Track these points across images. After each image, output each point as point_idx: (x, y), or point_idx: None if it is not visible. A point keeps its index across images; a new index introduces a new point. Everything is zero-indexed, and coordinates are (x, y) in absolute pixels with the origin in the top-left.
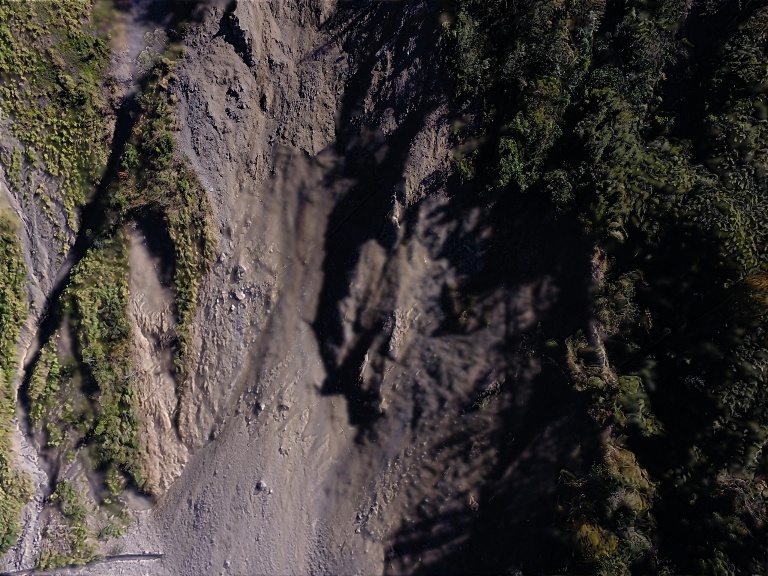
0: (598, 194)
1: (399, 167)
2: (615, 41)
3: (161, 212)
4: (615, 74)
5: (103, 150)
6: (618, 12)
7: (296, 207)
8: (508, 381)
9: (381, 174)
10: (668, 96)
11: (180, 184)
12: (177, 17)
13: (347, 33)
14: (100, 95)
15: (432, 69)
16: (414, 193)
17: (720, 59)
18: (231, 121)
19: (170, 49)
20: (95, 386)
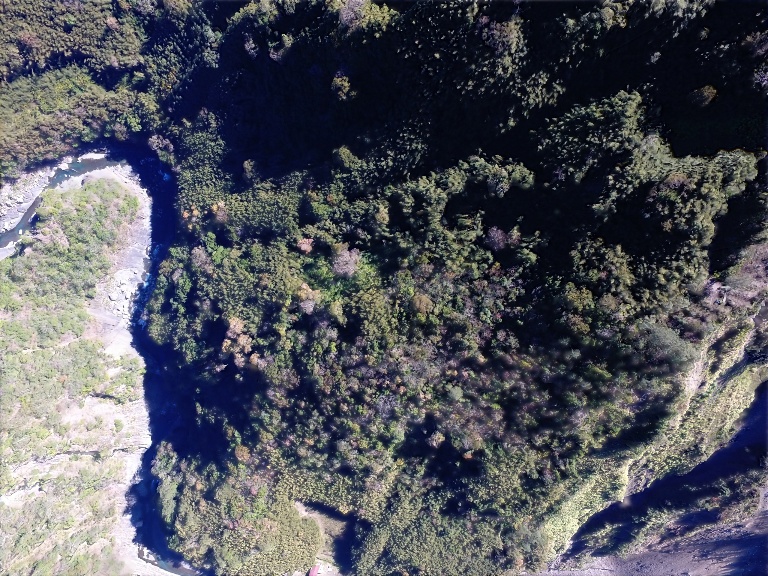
0: None
1: None
2: None
3: None
4: None
5: None
6: None
7: None
8: None
9: None
10: None
11: None
12: None
13: None
14: None
15: None
16: None
17: None
18: None
19: None
20: (627, 539)
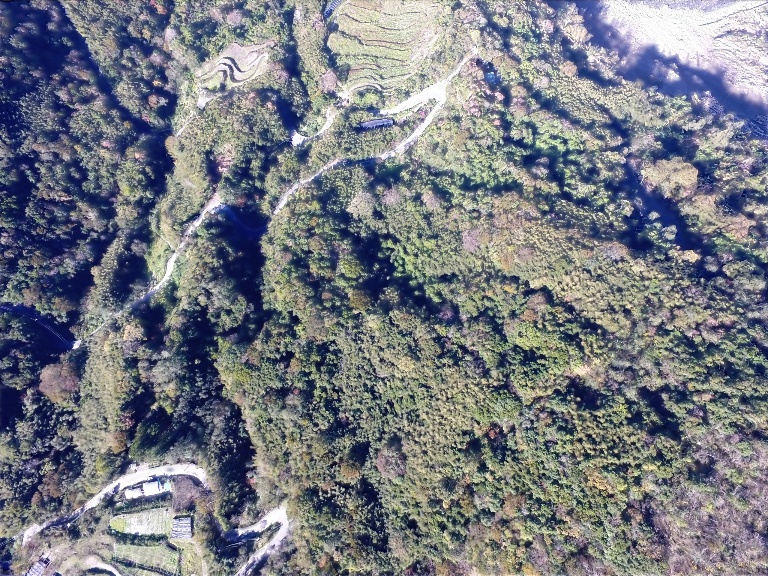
0: None
1: None
2: None
3: None
4: None
5: None
6: None
7: None
8: (620, 64)
9: None
10: None
11: None
12: None
13: None
14: None
15: None
16: None
17: None
18: None
19: None
20: None
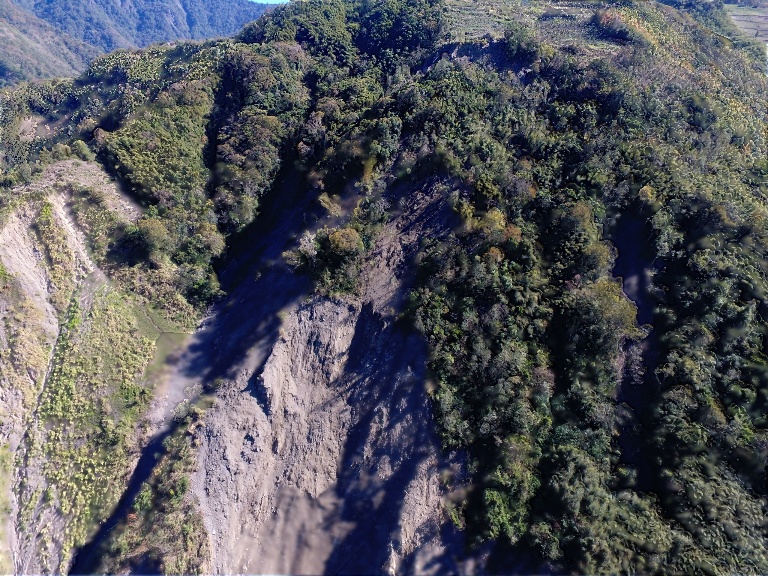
0: (585, 551)
1: (395, 514)
2: (569, 401)
3: (159, 559)
4: (575, 432)
5: (120, 487)
6: (566, 381)
7: (294, 551)
8: None
9: (378, 519)
10: (625, 447)
11: (185, 528)
12: (214, 371)
13: (351, 391)
14: (133, 436)
15: (421, 424)
16: (410, 542)
17: (658, 420)
18: (244, 463)
19: (203, 400)
20: None
